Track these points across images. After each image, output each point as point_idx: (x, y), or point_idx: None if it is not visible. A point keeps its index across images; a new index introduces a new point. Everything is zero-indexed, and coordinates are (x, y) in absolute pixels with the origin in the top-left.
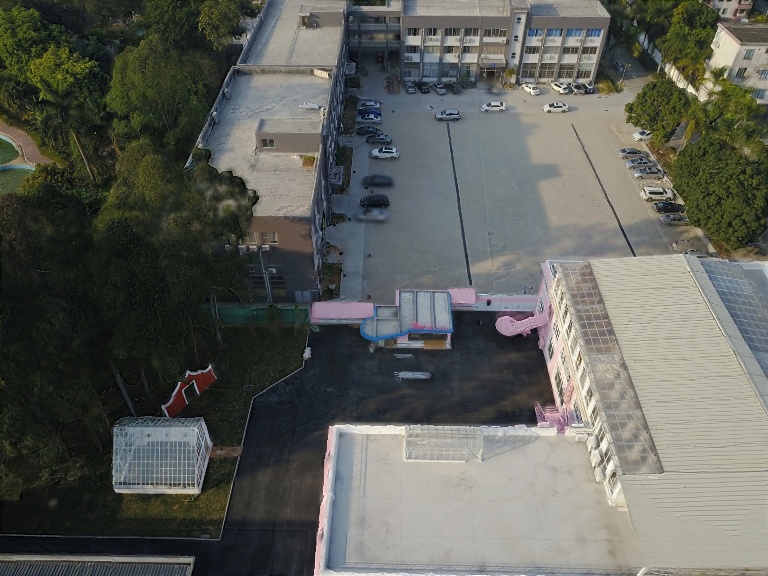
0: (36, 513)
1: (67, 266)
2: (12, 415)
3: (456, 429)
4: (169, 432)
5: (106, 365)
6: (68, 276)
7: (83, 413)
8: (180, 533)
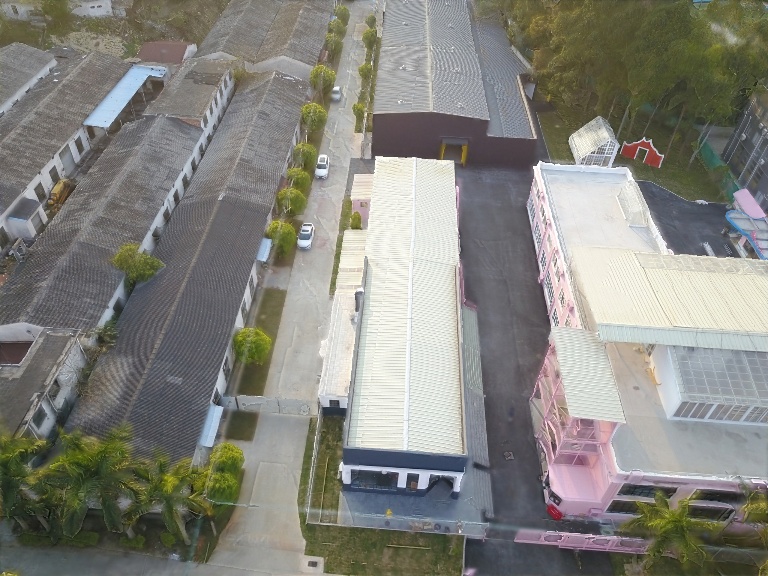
0: (550, 122)
1: (652, 4)
2: (575, 36)
3: (643, 200)
4: (604, 133)
5: (630, 91)
6: (647, 8)
7: (595, 81)
8: (553, 160)
